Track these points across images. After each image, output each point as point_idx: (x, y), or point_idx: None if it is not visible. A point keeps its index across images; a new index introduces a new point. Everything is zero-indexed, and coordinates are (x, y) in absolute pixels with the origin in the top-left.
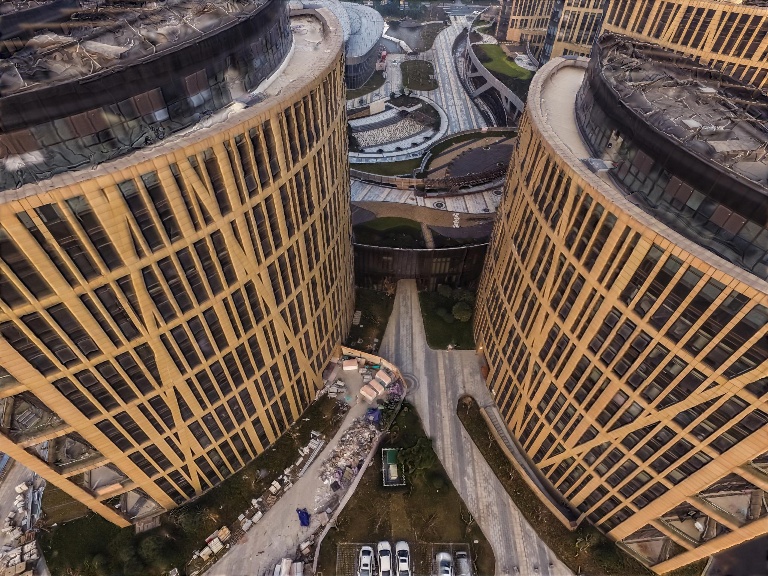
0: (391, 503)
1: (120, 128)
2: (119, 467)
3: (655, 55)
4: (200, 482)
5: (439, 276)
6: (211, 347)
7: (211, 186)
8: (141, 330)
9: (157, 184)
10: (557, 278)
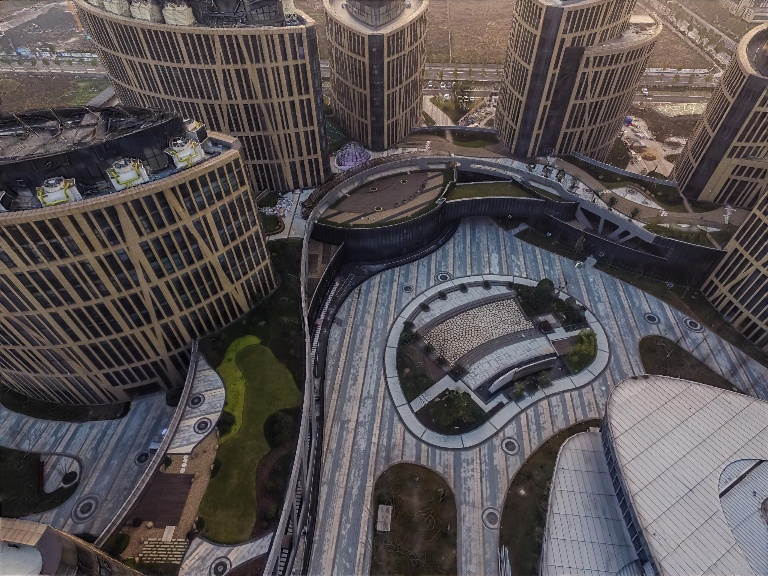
0: None
1: None
2: None
3: None
4: None
5: None
6: None
7: None
8: None
9: None
10: None
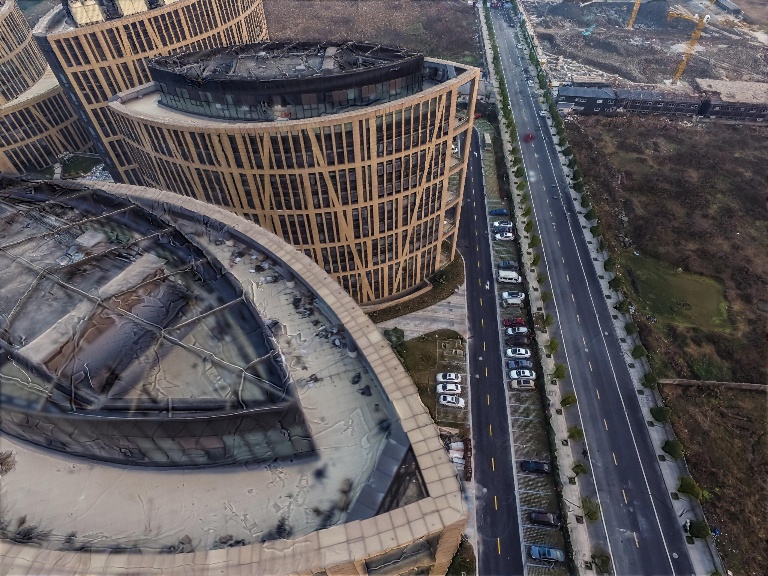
0: None
1: None
2: None
3: (192, 58)
4: None
5: None
6: None
7: None
8: None
9: None
10: (336, 187)
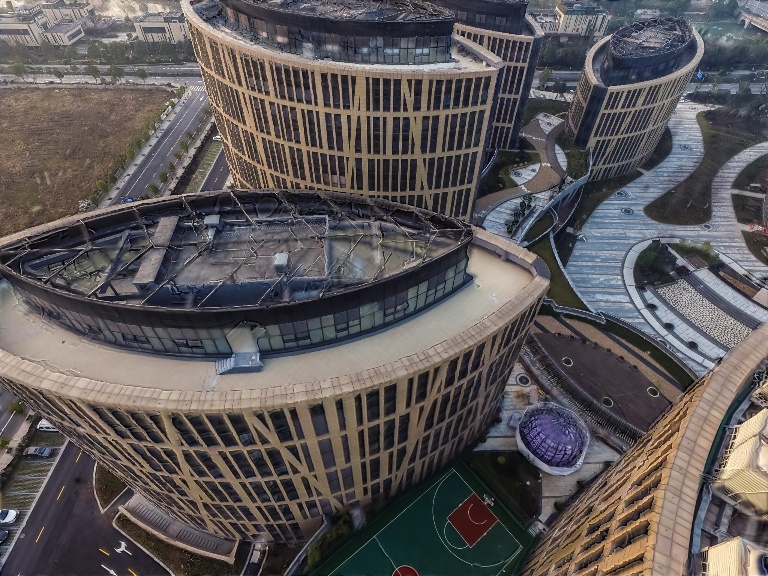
0: None
1: None
2: None
3: None
4: None
5: None
6: None
7: None
8: None
9: (218, 48)
10: None
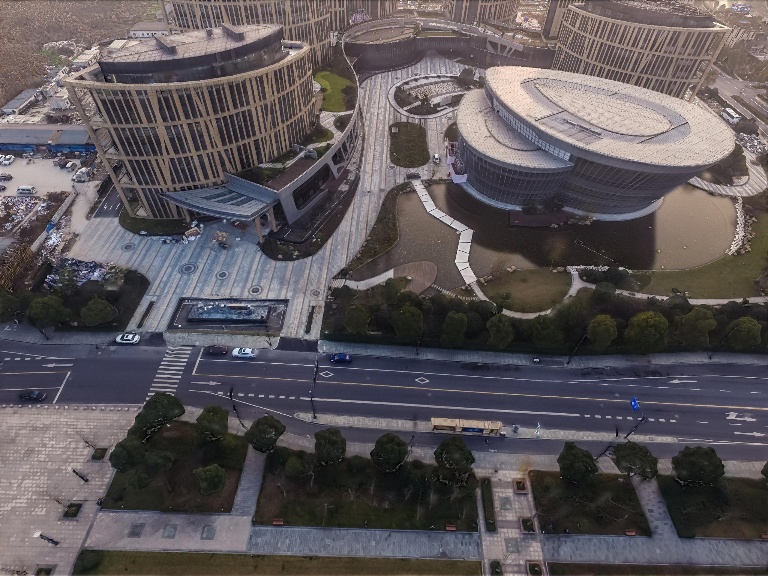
0: None
1: None
2: None
3: None
4: None
5: None
6: None
7: None
8: None
9: None
10: None
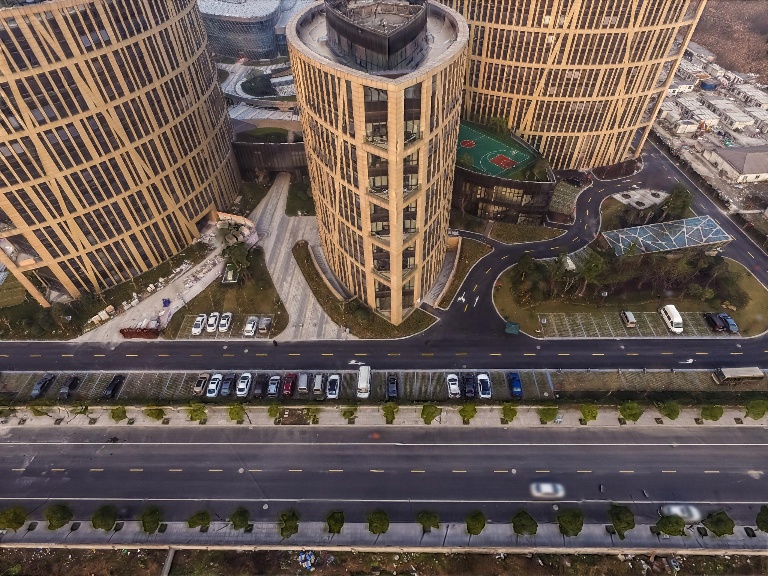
0: (227, 294)
1: (2, 3)
2: (28, 240)
3: None
4: (96, 279)
5: (301, 168)
6: (79, 156)
7: (54, 35)
8: (22, 125)
9: (16, 26)
10: None
